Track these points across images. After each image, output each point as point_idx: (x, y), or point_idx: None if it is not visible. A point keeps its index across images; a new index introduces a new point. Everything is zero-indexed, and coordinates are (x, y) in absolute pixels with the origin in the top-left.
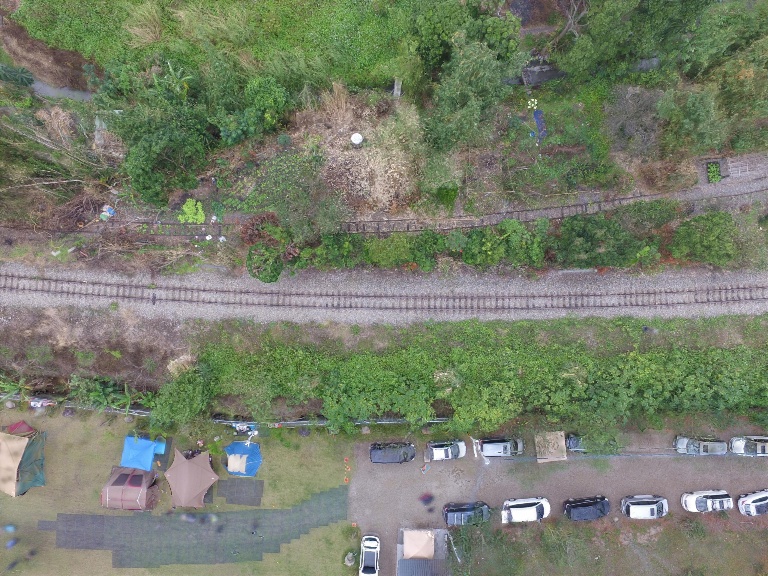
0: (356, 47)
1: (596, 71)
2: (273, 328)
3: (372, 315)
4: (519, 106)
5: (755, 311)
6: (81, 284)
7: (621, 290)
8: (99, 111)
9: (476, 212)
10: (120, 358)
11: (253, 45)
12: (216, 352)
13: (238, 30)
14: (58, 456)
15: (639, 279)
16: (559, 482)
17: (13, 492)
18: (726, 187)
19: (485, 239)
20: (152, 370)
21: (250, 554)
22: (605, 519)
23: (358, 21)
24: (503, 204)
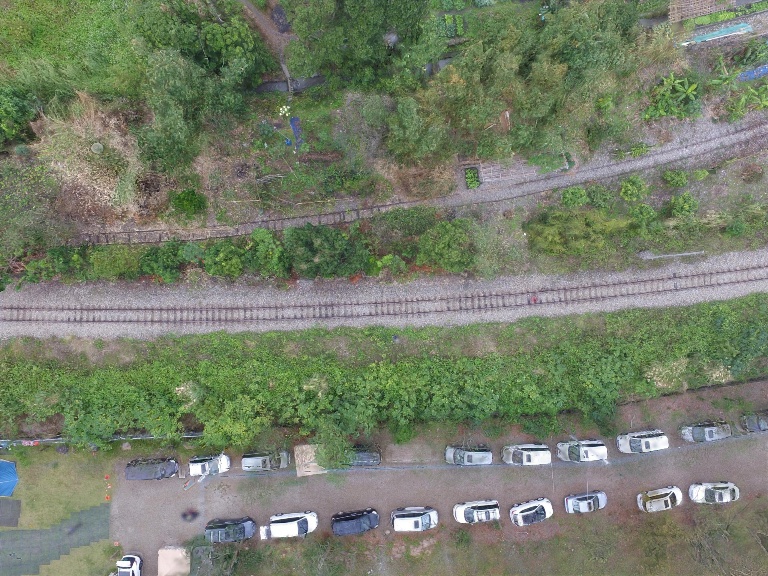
0: None
1: (351, 77)
2: (14, 344)
3: (116, 329)
4: (273, 113)
5: (508, 318)
6: None
7: (372, 299)
8: None
9: (230, 221)
10: None
11: (7, 53)
12: None
13: None
14: None
15: (391, 288)
16: (329, 495)
17: None
18: (486, 193)
19: None
20: None
21: None
22: (377, 532)
23: None
24: (258, 213)
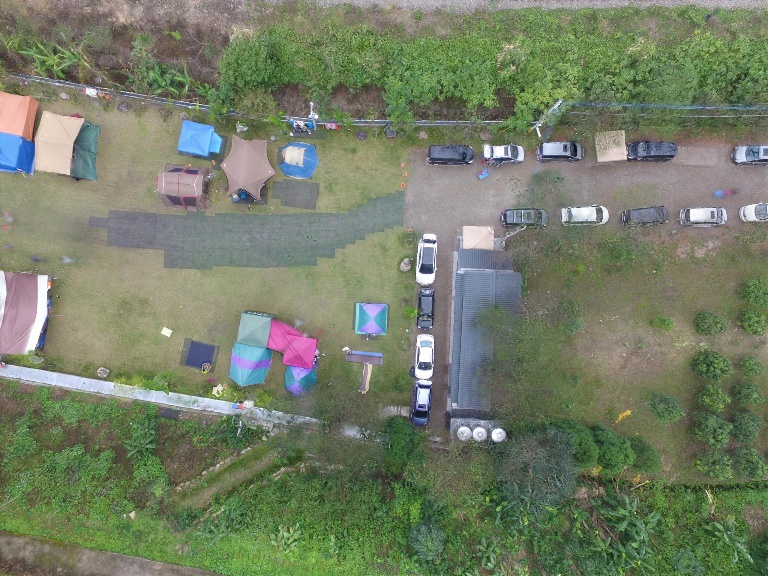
0: None
1: None
2: (335, 12)
3: None
4: None
5: None
6: None
7: None
8: None
9: None
10: (179, 41)
11: None
12: (278, 29)
13: None
14: (111, 151)
15: None
16: (617, 194)
17: (68, 169)
18: None
19: None
20: (211, 56)
21: (304, 258)
22: (663, 232)
23: None
24: None
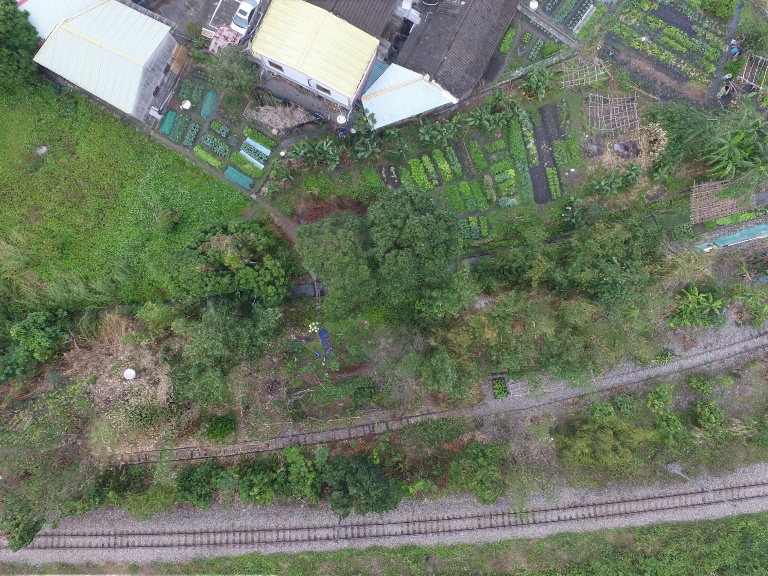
0: (144, 264)
1: None
2: (49, 570)
3: (149, 554)
4: (302, 327)
5: (538, 535)
6: None
7: (403, 518)
8: None
9: (261, 437)
10: None
11: (37, 266)
12: None
13: (15, 258)
14: None
15: (422, 505)
16: None
17: None
18: (514, 401)
19: None
20: None
21: None
22: None
23: (145, 238)
24: (288, 428)
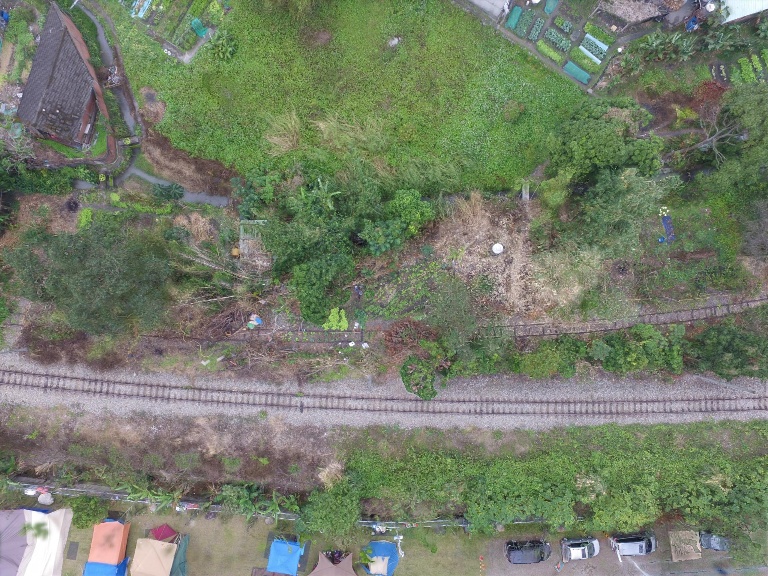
0: (485, 153)
1: None
2: (417, 434)
3: (514, 420)
4: None
5: None
6: (231, 393)
7: (755, 394)
8: (244, 221)
9: (609, 316)
10: (266, 464)
11: (386, 152)
12: (364, 459)
13: (376, 140)
14: (200, 558)
15: None
16: None
17: None
18: None
19: (628, 349)
20: (297, 475)
21: None
22: None
23: (487, 128)
24: (635, 308)
